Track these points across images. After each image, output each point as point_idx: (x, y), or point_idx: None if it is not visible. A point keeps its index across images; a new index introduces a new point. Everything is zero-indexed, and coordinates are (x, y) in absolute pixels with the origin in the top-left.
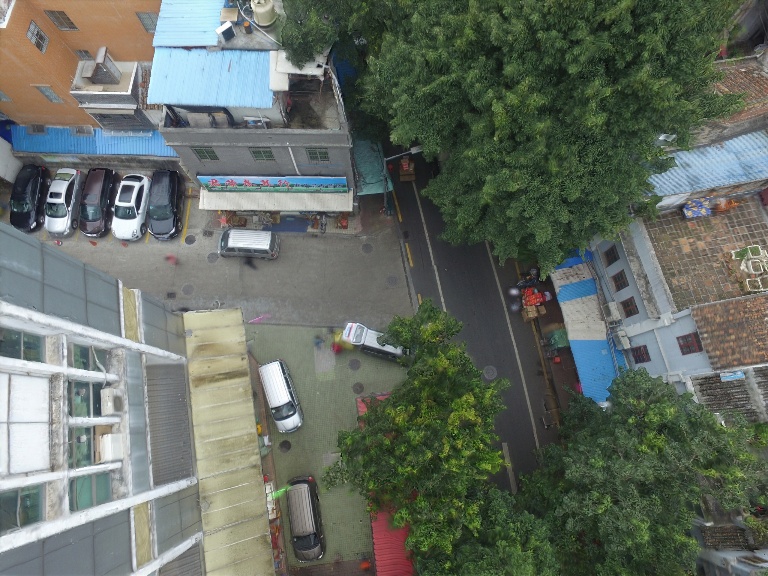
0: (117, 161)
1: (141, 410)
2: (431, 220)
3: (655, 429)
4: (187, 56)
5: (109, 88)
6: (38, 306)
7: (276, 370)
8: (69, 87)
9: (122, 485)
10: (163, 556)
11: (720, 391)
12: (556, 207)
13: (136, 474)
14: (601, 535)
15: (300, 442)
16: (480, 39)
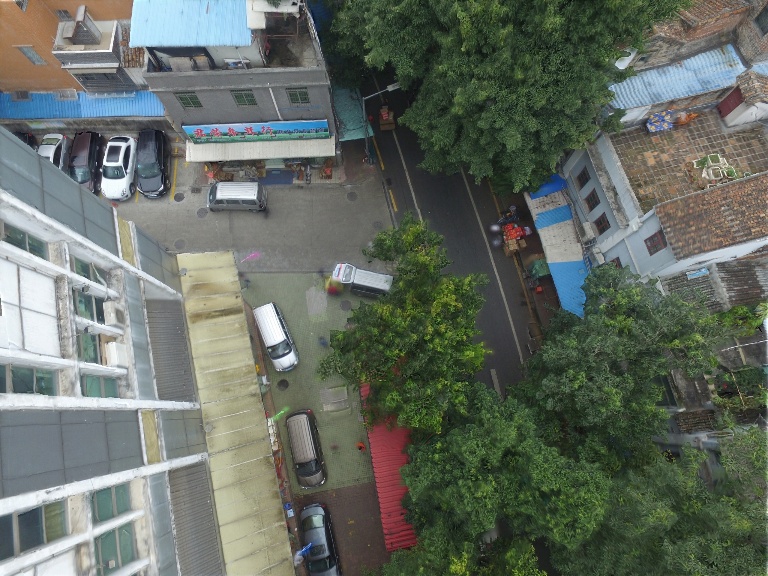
0: (102, 124)
1: (142, 329)
2: (412, 167)
3: (625, 315)
4: (166, 0)
5: (90, 48)
6: (40, 209)
7: (270, 311)
8: (51, 47)
9: (129, 390)
10: (172, 461)
11: (687, 288)
12: (524, 117)
13: (141, 383)
14: (579, 412)
15: (297, 380)
16: None
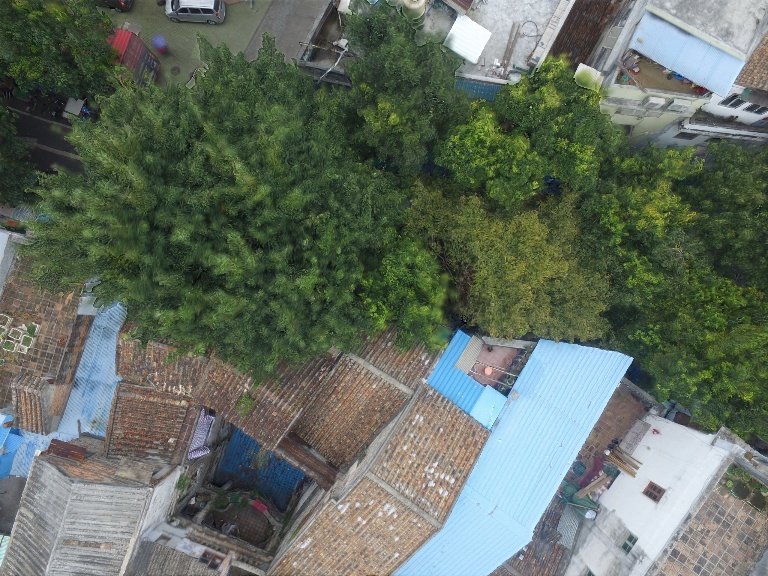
0: None
1: None
2: None
3: None
4: None
5: None
6: None
7: (205, 3)
8: None
9: None
10: None
11: None
12: None
13: None
14: None
15: (159, 13)
16: None
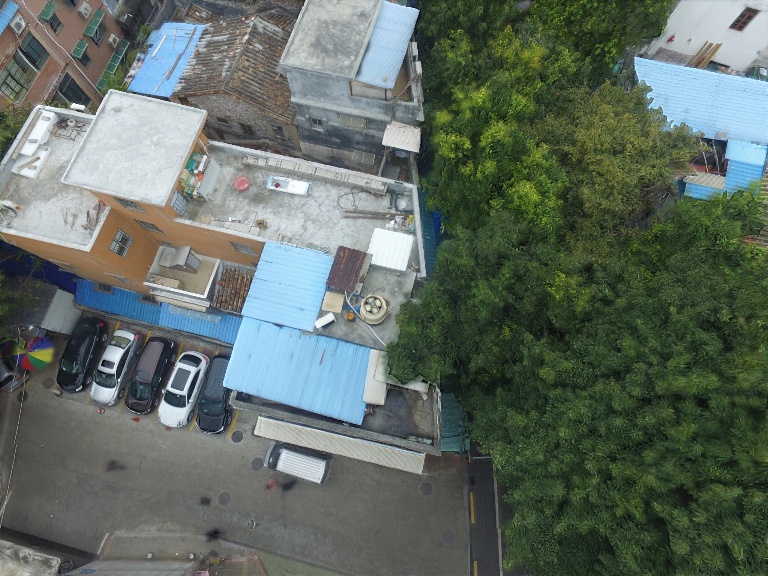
0: (178, 333)
1: None
2: None
3: None
4: (277, 334)
5: (185, 276)
6: None
7: None
8: (144, 278)
9: None
10: None
11: None
12: None
13: None
14: None
15: None
16: (644, 497)
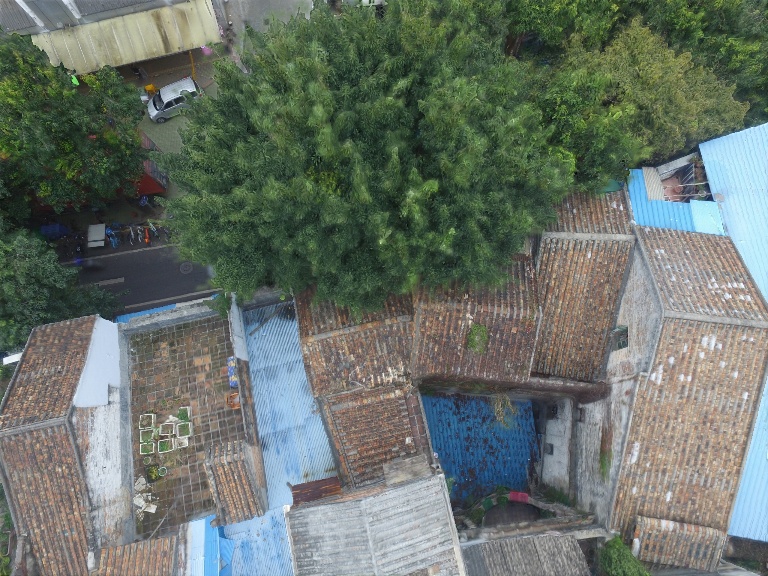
0: None
1: None
2: None
3: None
4: None
5: None
6: None
7: (187, 88)
8: None
9: None
10: None
11: None
12: None
13: None
14: None
15: (143, 123)
16: None
